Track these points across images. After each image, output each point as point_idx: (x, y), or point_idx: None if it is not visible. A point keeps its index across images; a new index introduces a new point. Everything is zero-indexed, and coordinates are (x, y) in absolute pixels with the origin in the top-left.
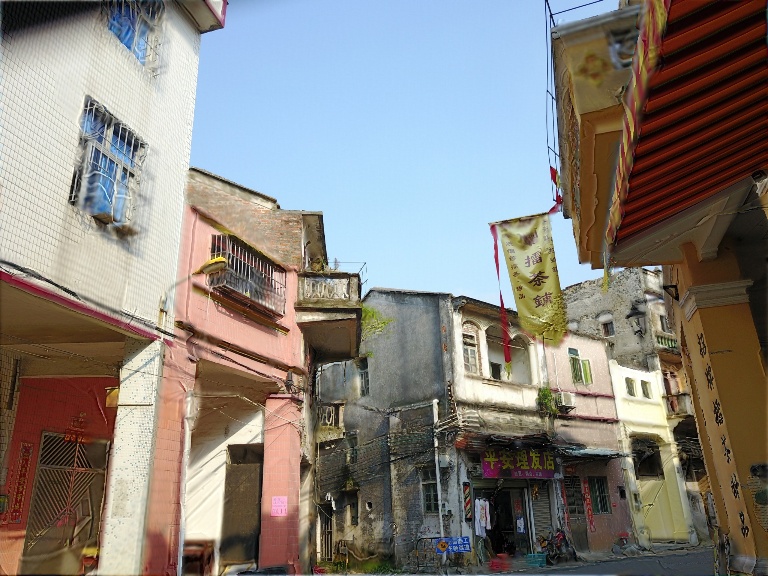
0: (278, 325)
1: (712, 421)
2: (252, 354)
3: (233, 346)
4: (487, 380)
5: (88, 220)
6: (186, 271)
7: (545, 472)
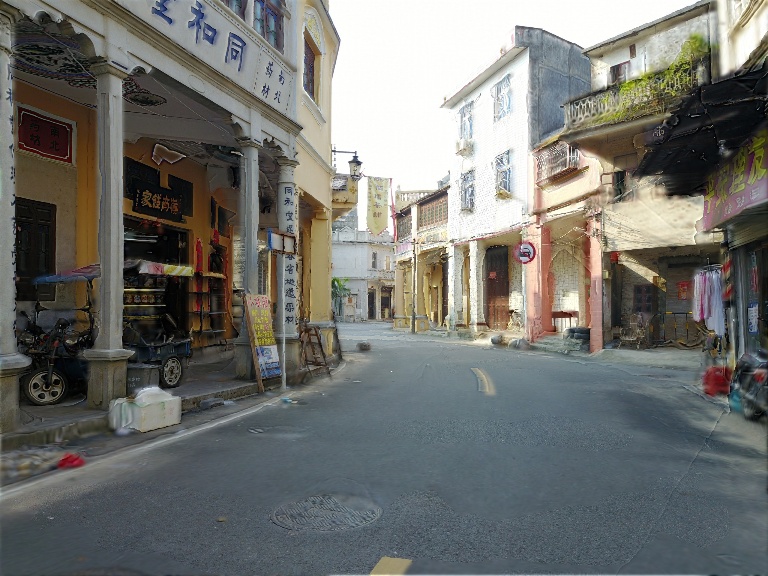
0: (581, 169)
1: None
2: (561, 205)
3: (551, 208)
4: (749, 9)
5: (501, 201)
6: (531, 187)
7: (766, 182)
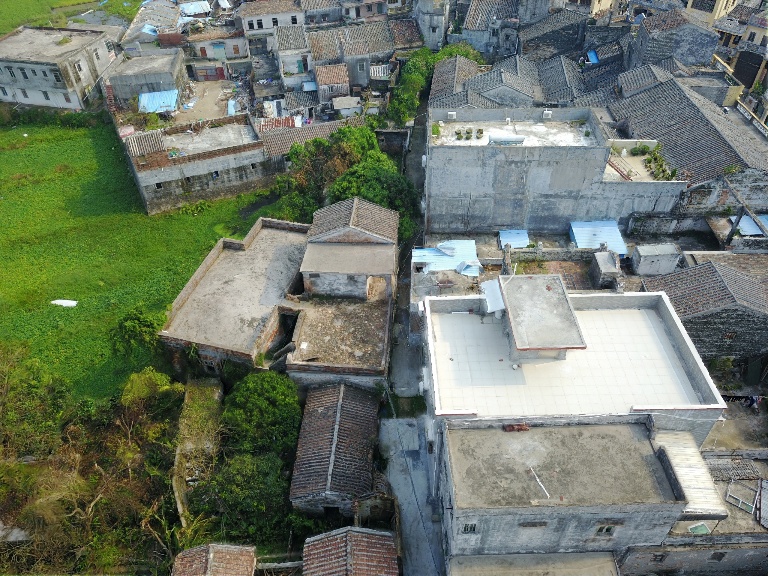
0: None
1: None
2: None
3: None
4: None
5: None
6: None
7: None
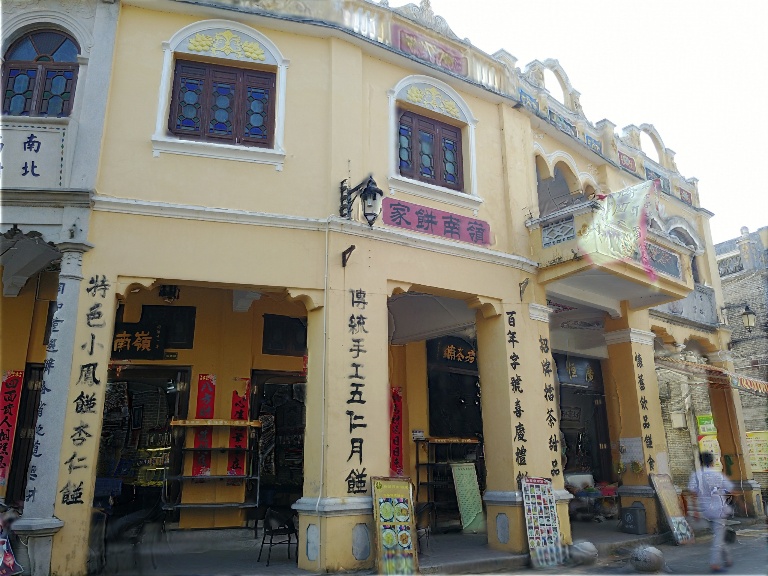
0: None
1: (539, 395)
2: None
3: None
4: None
5: None
6: None
7: None
